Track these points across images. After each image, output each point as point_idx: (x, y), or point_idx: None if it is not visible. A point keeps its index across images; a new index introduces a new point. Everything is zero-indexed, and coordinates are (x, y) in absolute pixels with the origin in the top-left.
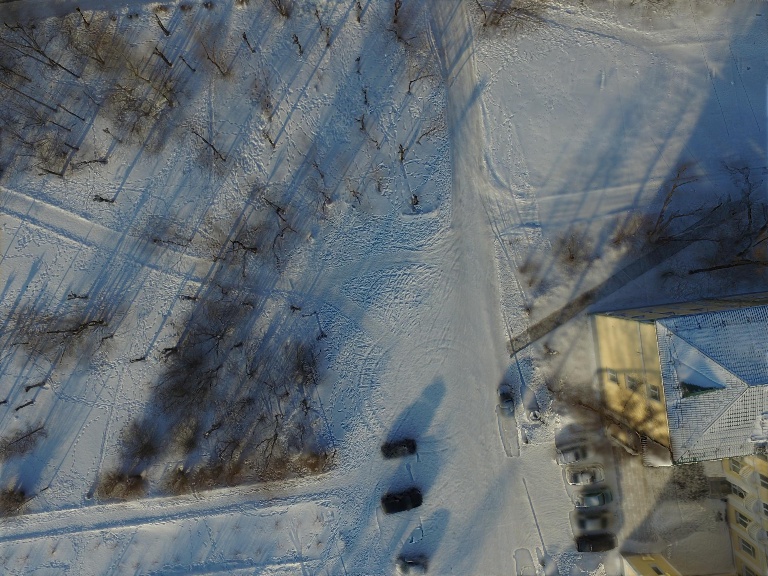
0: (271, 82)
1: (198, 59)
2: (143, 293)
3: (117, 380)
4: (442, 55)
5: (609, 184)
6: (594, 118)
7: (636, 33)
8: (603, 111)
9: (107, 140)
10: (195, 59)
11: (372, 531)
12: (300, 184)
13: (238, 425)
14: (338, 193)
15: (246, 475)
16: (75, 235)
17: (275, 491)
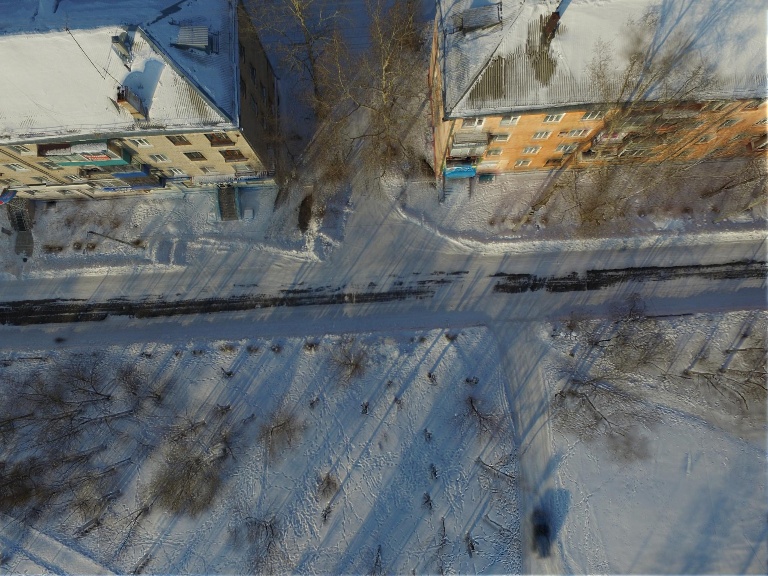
0: (333, 435)
1: (258, 403)
2: None
3: None
4: (515, 418)
5: None
6: (680, 507)
7: (723, 414)
8: (690, 499)
9: (151, 484)
10: (255, 402)
11: None
12: (354, 553)
13: None
14: (395, 568)
15: None
16: None
17: None
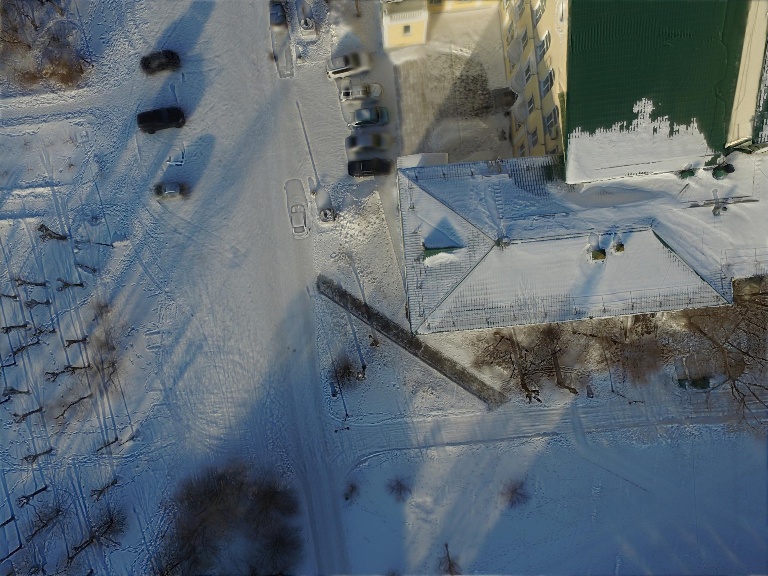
0: None
1: None
2: None
3: None
4: None
5: None
6: None
7: None
8: None
9: None
10: None
11: (131, 156)
12: None
13: None
14: None
15: None
16: None
17: (26, 108)
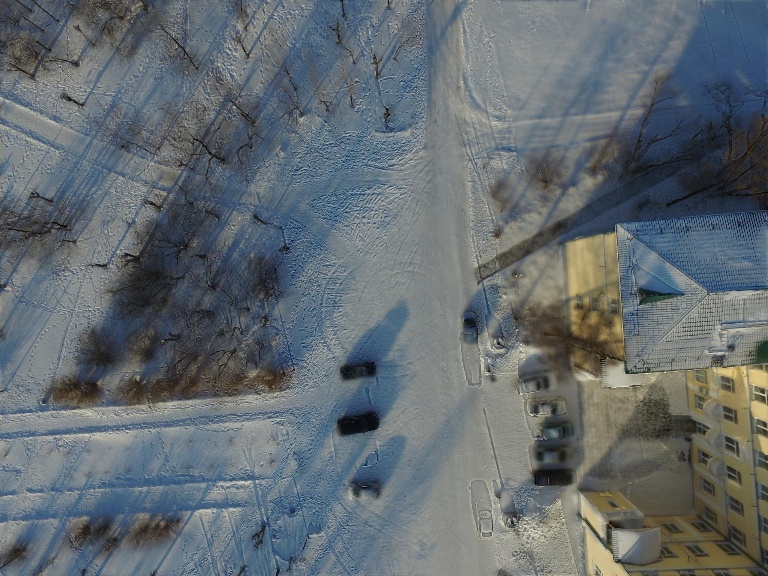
0: None
1: None
2: (108, 199)
3: (78, 286)
4: None
5: (589, 111)
6: (577, 41)
7: None
8: (587, 35)
9: (80, 42)
10: None
11: (327, 453)
12: (272, 96)
13: (197, 338)
14: (310, 107)
15: (202, 389)
16: (43, 137)
17: (231, 407)
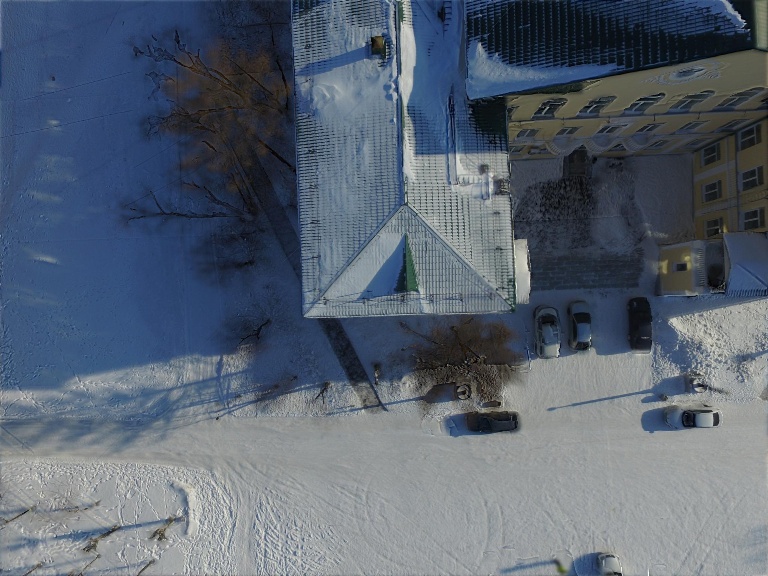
0: None
1: None
2: None
3: None
4: None
5: (177, 263)
6: (92, 276)
7: None
8: (84, 264)
9: None
10: None
11: None
12: None
13: None
14: None
15: None
16: None
17: None
